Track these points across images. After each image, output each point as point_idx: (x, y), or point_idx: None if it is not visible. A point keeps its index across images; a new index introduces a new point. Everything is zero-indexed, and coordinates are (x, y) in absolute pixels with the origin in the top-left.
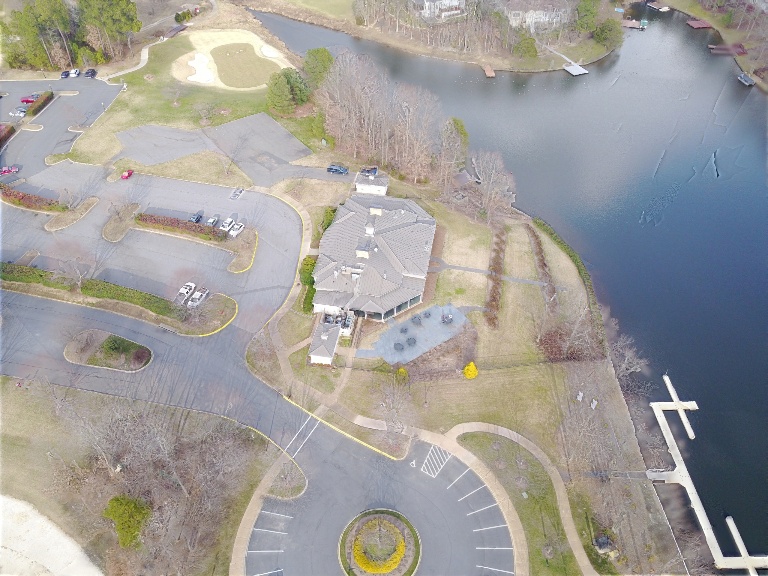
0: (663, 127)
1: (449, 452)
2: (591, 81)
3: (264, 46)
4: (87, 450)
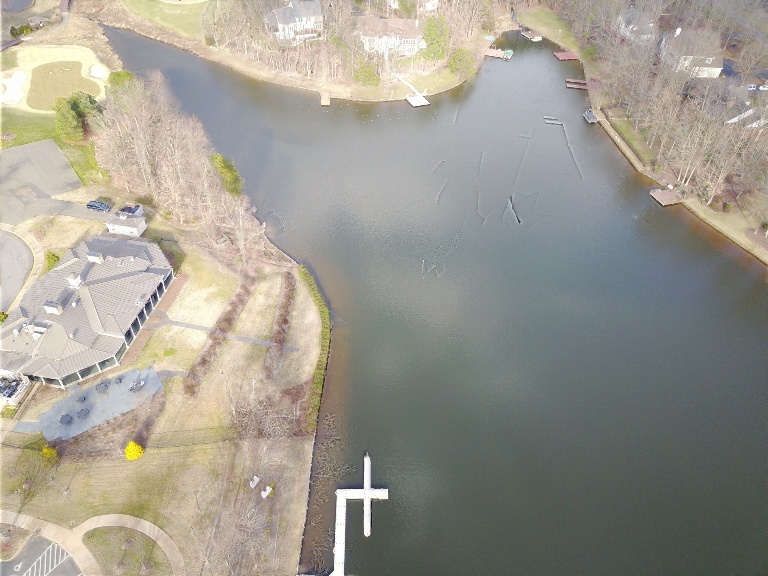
0: (489, 165)
1: (67, 552)
2: (441, 112)
3: (96, 65)
4: None
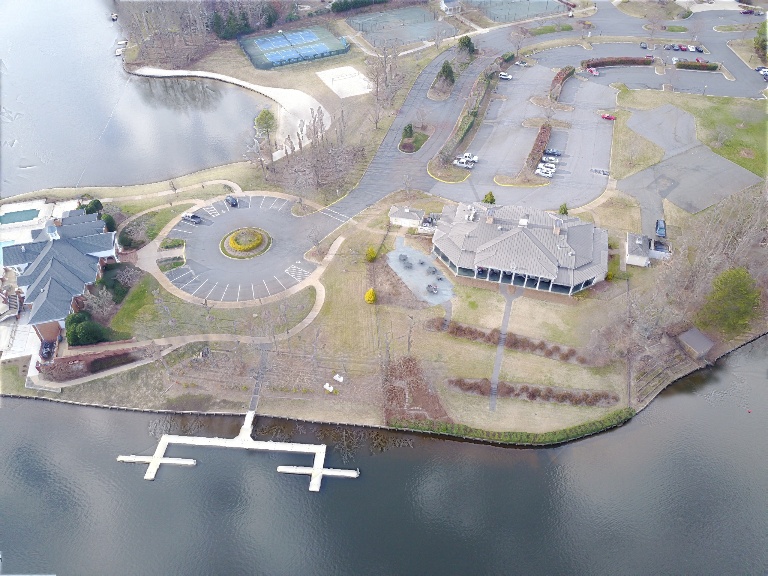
0: None
1: (303, 281)
2: None
3: None
4: (348, 145)
